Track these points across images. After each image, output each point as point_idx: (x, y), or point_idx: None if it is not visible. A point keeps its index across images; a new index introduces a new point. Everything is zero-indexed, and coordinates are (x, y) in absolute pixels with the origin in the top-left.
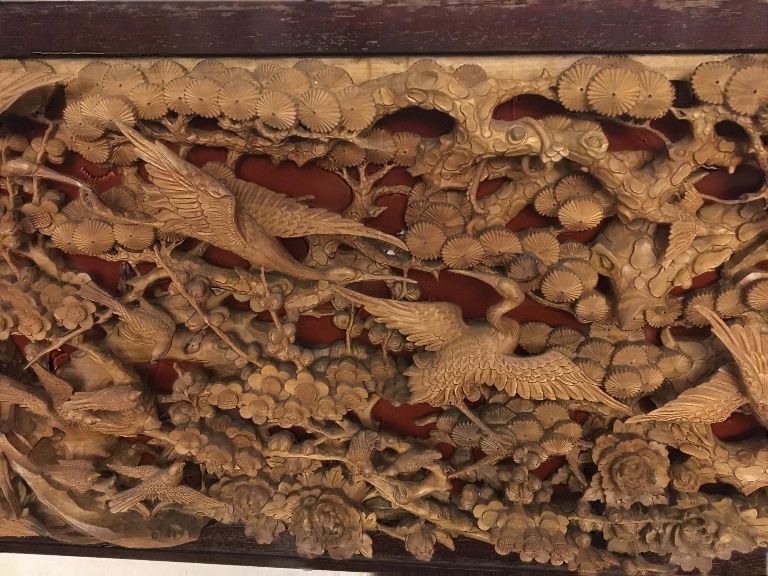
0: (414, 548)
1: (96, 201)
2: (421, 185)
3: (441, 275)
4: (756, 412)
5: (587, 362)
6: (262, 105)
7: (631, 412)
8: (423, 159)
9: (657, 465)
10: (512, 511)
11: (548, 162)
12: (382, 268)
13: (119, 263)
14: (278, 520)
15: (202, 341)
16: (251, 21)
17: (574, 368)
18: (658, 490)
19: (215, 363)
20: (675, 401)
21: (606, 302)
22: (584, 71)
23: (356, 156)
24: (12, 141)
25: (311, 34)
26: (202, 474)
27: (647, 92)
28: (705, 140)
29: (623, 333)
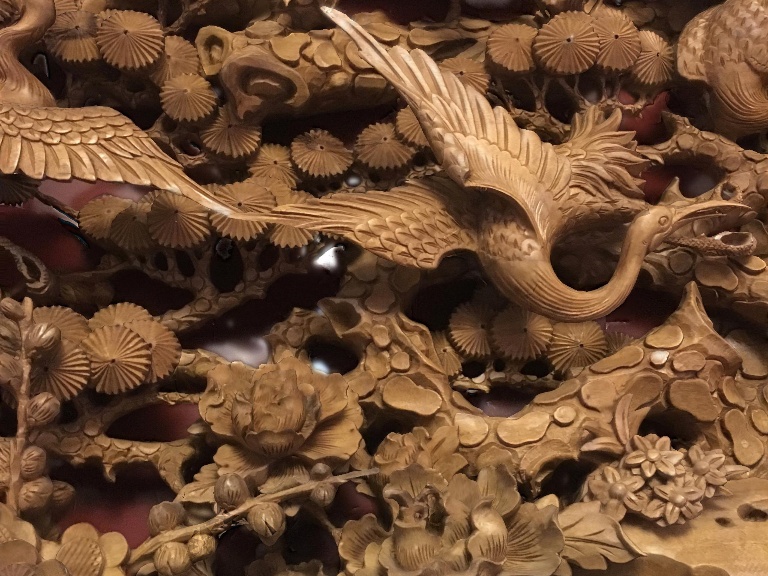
0: None
1: None
2: None
3: None
4: (489, 258)
5: None
6: None
7: None
8: None
9: (331, 402)
10: None
11: None
12: None
13: None
14: None
15: None
16: None
17: (136, 132)
18: (336, 455)
19: None
20: (326, 199)
21: (210, 87)
22: None
23: None
24: None
25: None
26: None
27: None
28: None
29: None
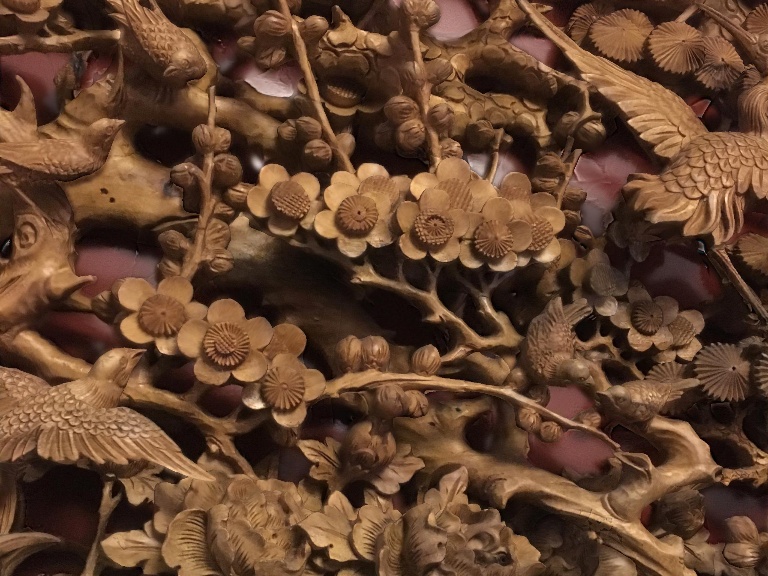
0: None
1: None
2: (587, 6)
3: None
4: None
5: None
6: None
7: None
8: None
9: None
10: None
11: None
12: (534, 108)
13: None
14: None
15: None
16: None
17: None
18: None
19: None
20: None
21: None
22: None
23: None
24: None
25: None
26: (99, 525)
27: None
28: None
29: None
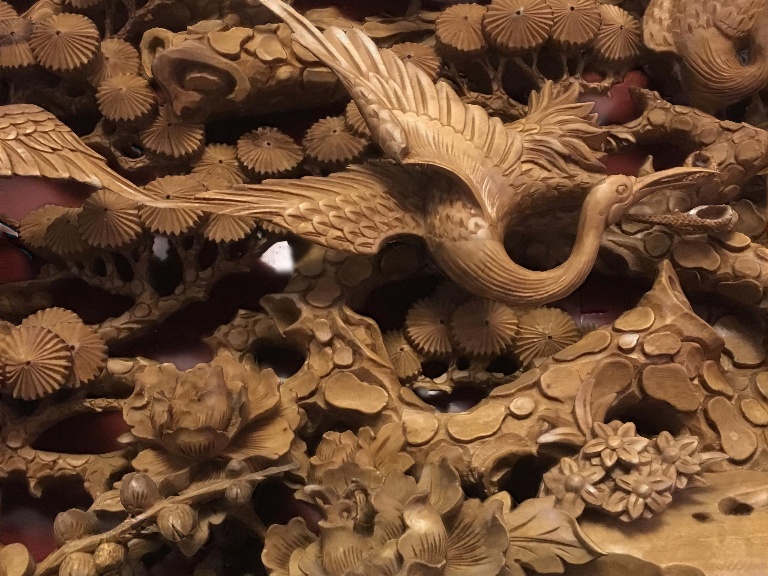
0: None
1: None
2: None
3: None
4: (436, 241)
5: None
6: None
7: None
8: None
9: (262, 400)
10: None
11: None
12: None
13: None
14: None
15: None
16: None
17: (59, 127)
18: None
19: None
20: (256, 185)
21: (148, 85)
22: None
23: None
24: None
25: None
26: None
27: None
28: None
29: None
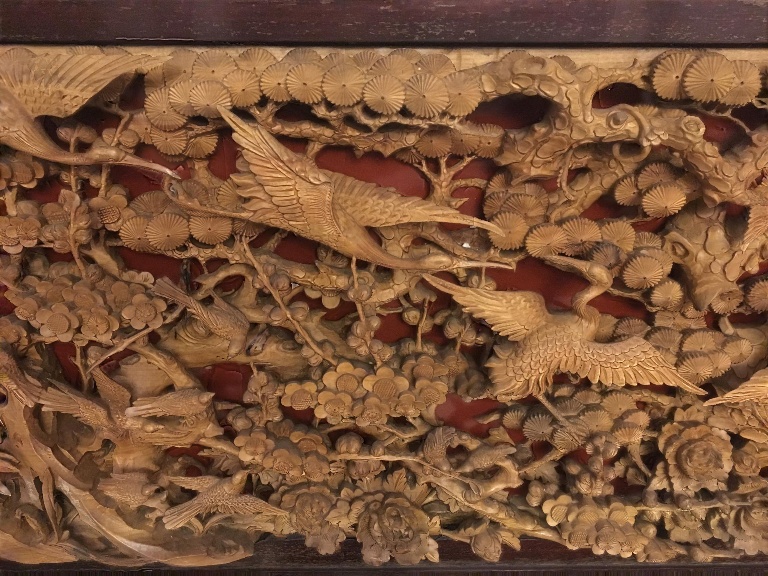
0: (483, 549)
1: (182, 190)
2: (500, 177)
3: (518, 266)
4: None
5: (659, 349)
6: (371, 89)
7: (690, 401)
8: (514, 148)
9: (722, 450)
10: (583, 504)
11: (647, 146)
12: None
13: (180, 262)
14: (339, 529)
15: (266, 342)
16: (350, 9)
17: (655, 353)
18: (723, 475)
19: (278, 365)
20: (748, 383)
21: (680, 288)
22: (679, 60)
23: (442, 146)
24: (82, 132)
25: (410, 23)
26: (253, 486)
27: (739, 79)
28: None
29: (686, 321)
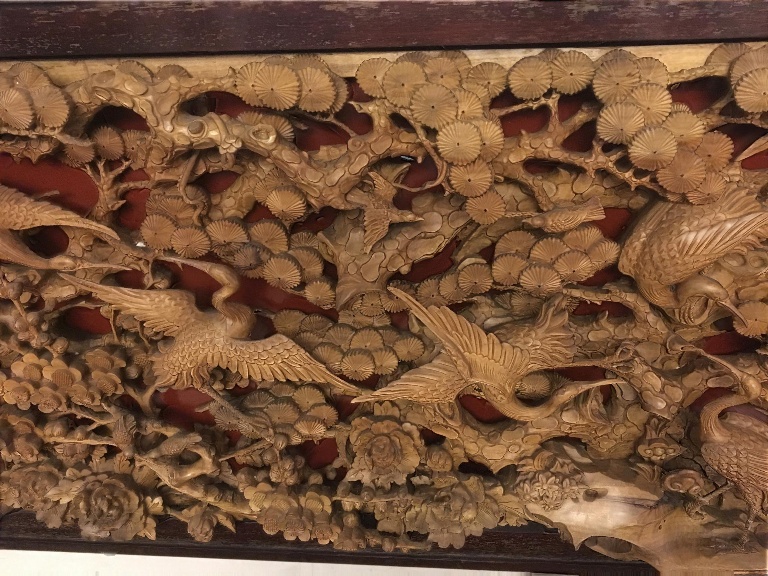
0: (191, 530)
1: None
2: None
3: (184, 265)
4: (482, 391)
5: (325, 346)
6: None
7: None
8: None
9: (406, 445)
10: (275, 492)
11: (227, 154)
12: None
13: None
14: (70, 505)
15: None
16: None
17: (299, 350)
18: (409, 469)
19: None
20: (398, 381)
21: (331, 288)
22: (254, 68)
23: (85, 153)
24: None
25: (19, 38)
26: (5, 462)
27: (308, 87)
28: (382, 132)
29: (368, 319)
